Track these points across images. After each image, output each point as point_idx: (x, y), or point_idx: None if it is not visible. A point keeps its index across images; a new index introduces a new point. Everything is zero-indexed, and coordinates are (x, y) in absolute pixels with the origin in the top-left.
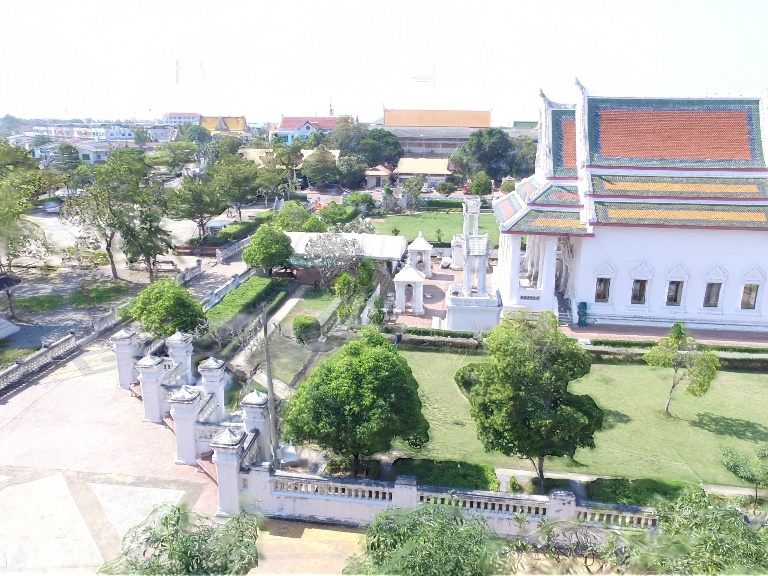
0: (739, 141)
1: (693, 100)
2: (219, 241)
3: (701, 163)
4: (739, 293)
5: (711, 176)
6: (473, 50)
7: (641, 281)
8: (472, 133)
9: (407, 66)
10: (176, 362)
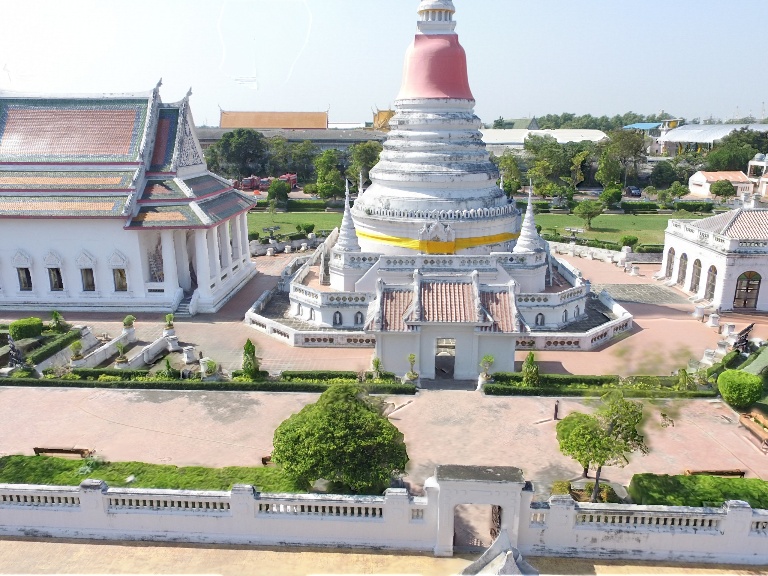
0: (123, 137)
1: (92, 100)
2: None
3: (83, 158)
4: (110, 277)
5: (89, 170)
6: (297, 53)
7: (24, 269)
8: (223, 134)
9: (228, 68)
10: None
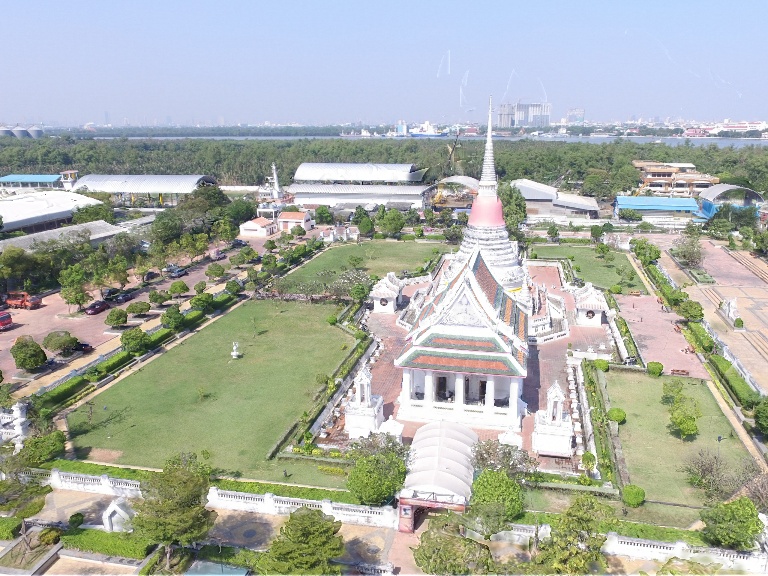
0: None
1: None
2: None
3: None
4: None
5: None
6: None
7: None
8: None
9: None
10: (764, 531)
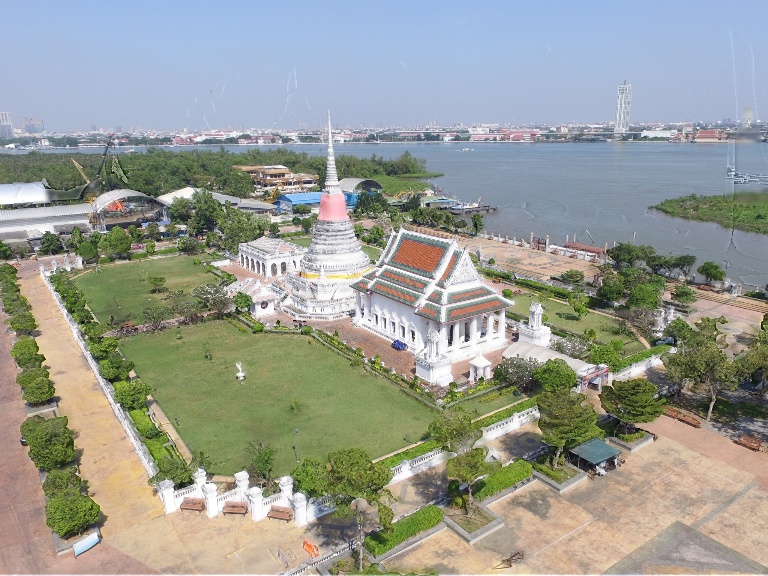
0: None
1: None
2: (613, 420)
3: None
4: None
5: None
6: None
7: None
8: None
9: None
10: None
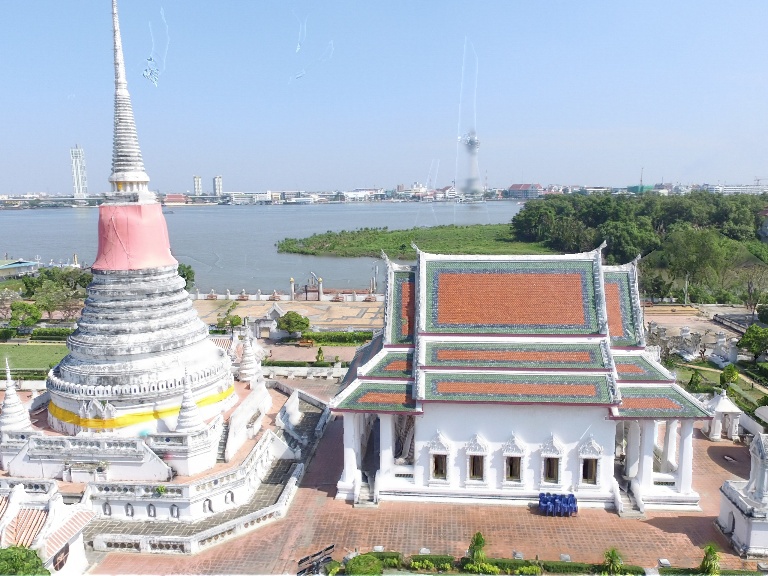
0: None
1: None
2: None
3: None
4: None
5: None
6: None
7: None
8: None
9: None
10: None
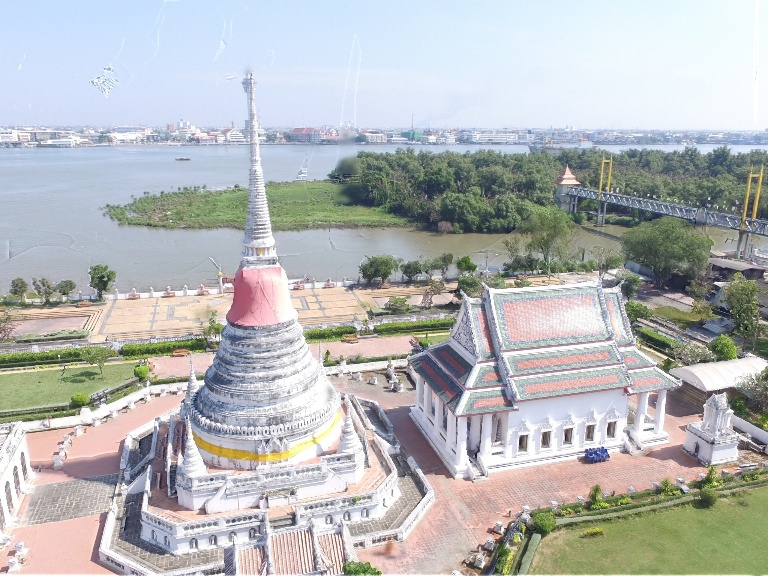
0: None
1: None
2: None
3: None
4: None
5: None
6: None
7: None
8: None
9: None
10: None
